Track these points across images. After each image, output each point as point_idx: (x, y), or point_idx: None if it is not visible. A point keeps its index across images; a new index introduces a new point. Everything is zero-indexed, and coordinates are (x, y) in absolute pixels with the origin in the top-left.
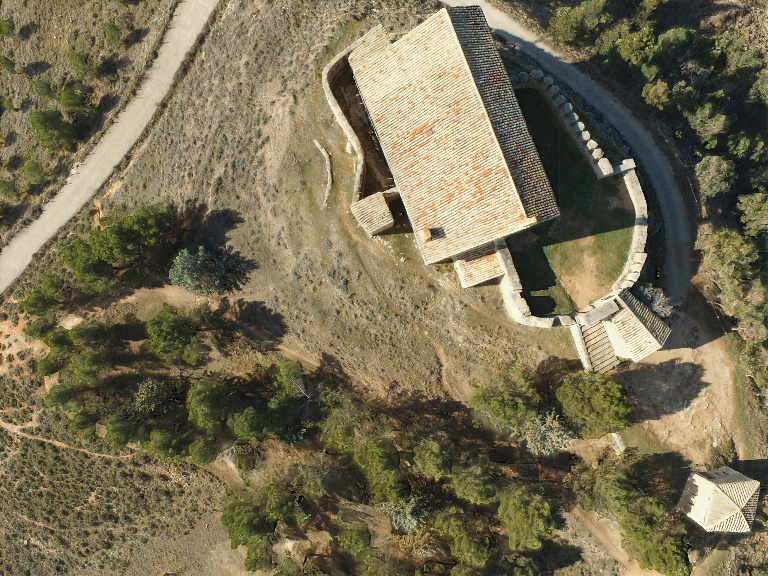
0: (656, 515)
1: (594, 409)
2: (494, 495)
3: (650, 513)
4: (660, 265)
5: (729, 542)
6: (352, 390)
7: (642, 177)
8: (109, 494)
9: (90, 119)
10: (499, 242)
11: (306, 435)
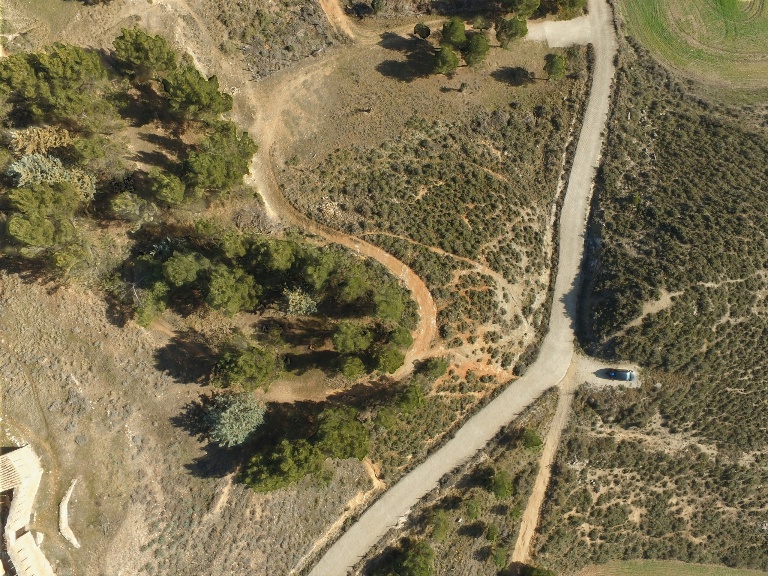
0: None
1: None
2: None
3: None
4: None
5: None
6: None
7: None
8: (403, 196)
9: (378, 572)
10: None
11: None
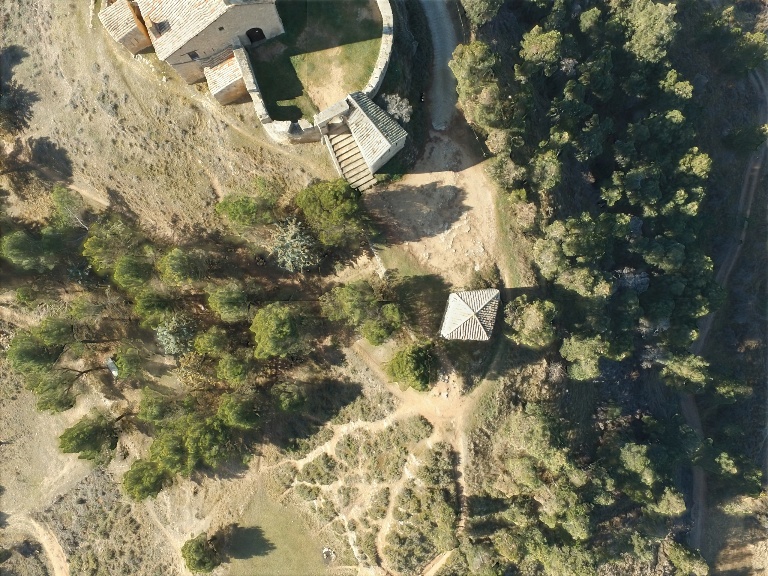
0: (395, 322)
1: (322, 206)
2: (239, 303)
3: (389, 319)
4: (425, 90)
5: (498, 372)
6: (140, 229)
7: (411, 3)
8: None
9: None
10: (235, 43)
11: (102, 279)
